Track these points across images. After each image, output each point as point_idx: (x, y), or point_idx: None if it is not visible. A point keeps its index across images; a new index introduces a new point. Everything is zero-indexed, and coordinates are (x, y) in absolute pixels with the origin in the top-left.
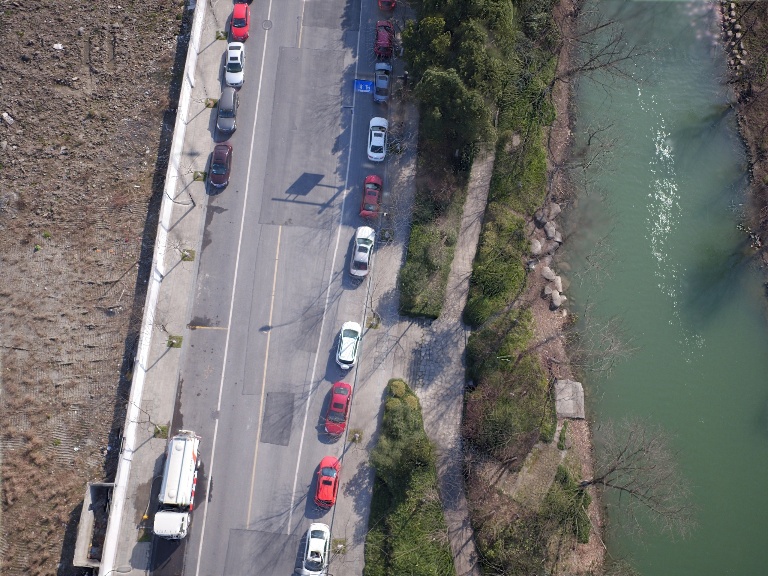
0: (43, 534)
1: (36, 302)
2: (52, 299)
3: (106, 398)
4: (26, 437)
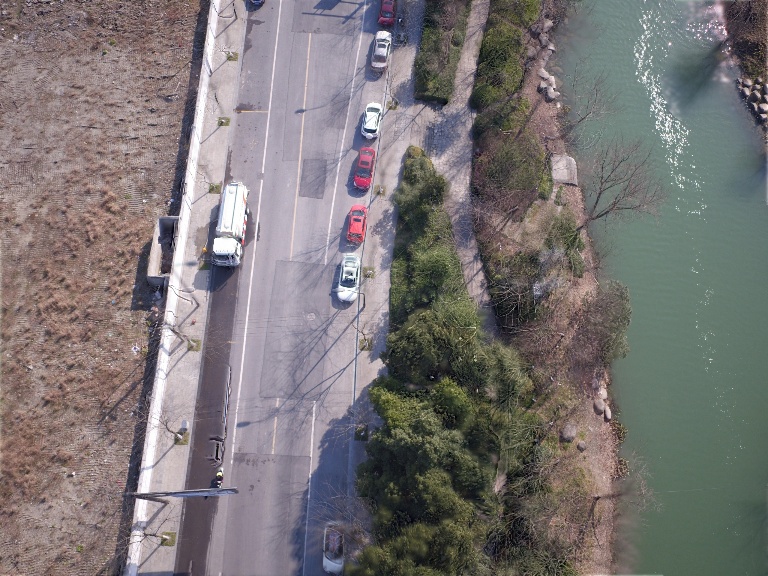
0: (120, 264)
1: (106, 93)
2: (119, 90)
3: (168, 163)
4: (102, 192)
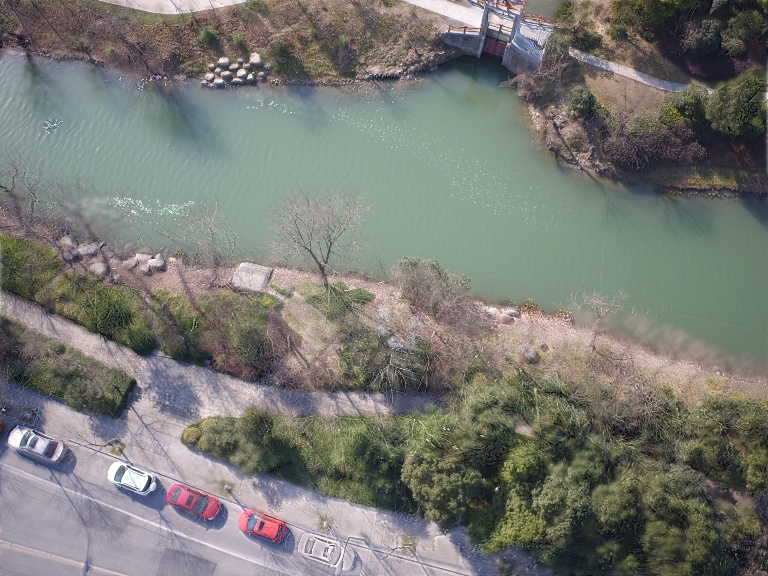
0: None
1: None
2: None
3: None
4: None
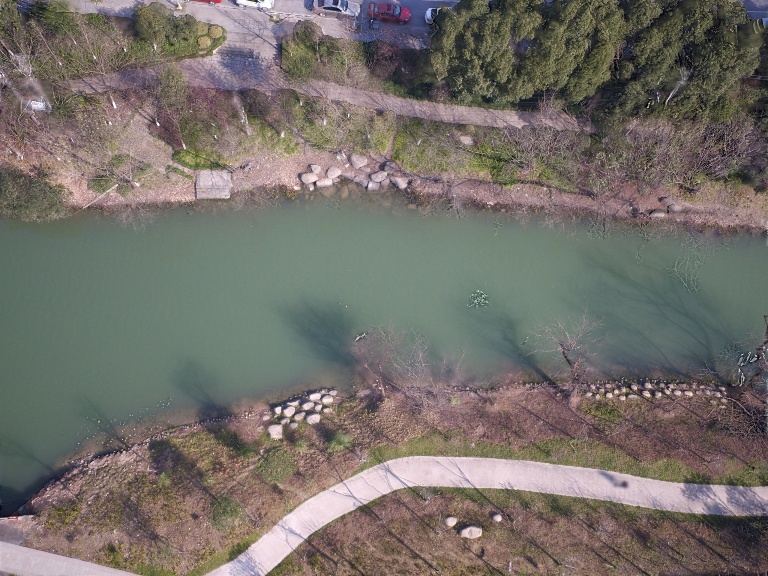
0: None
1: None
2: None
3: None
4: None
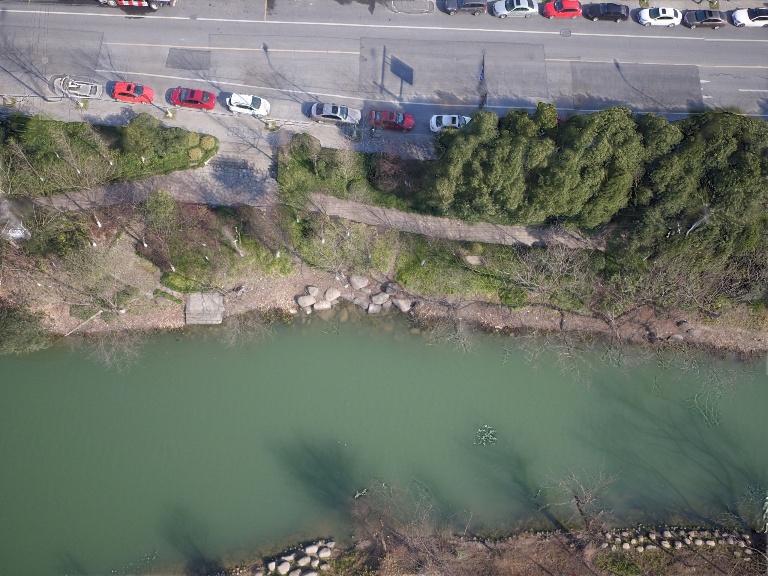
0: None
1: None
2: None
3: None
4: None
